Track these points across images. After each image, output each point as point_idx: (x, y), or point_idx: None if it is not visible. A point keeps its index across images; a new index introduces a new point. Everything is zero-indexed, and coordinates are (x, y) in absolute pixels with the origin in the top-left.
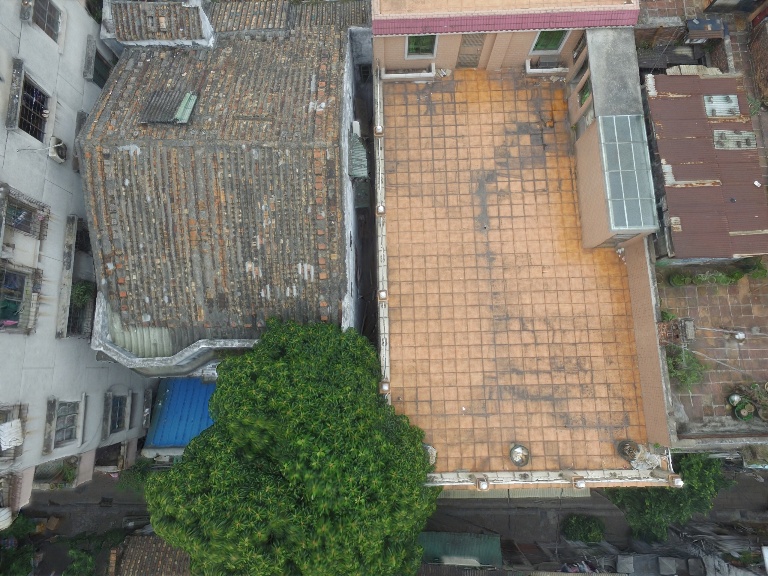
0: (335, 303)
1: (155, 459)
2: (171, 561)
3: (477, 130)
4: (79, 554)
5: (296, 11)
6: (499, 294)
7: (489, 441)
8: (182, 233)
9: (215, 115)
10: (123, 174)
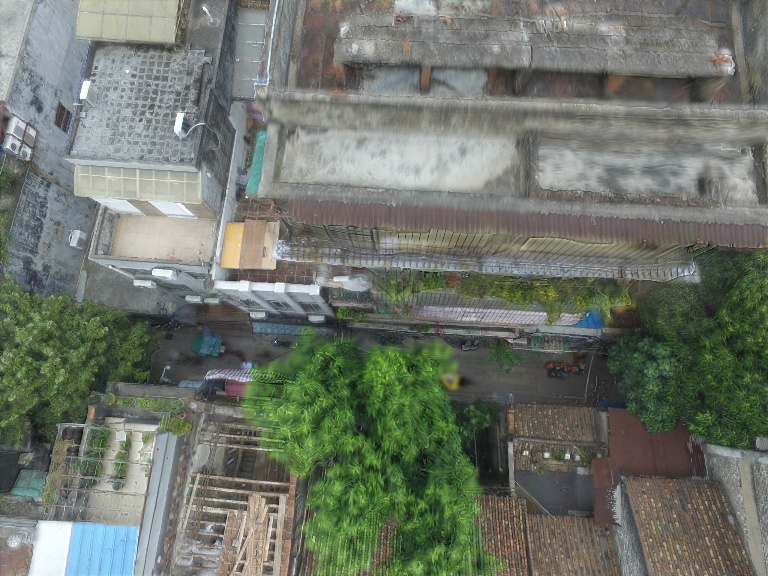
0: None
1: (515, 341)
2: (563, 427)
3: None
4: (474, 412)
5: None
6: None
7: None
8: None
9: None
10: None
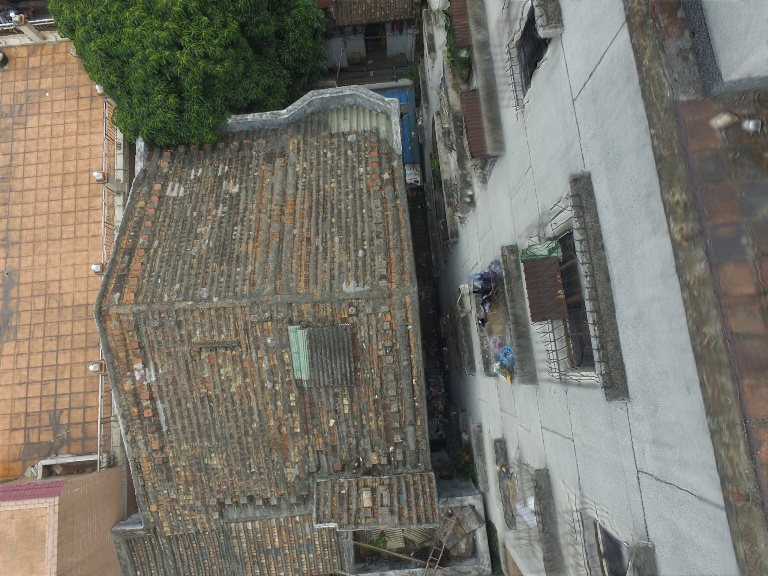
0: (152, 166)
1: None
2: (368, 0)
3: (3, 393)
4: None
5: (229, 564)
6: (1, 204)
7: (27, 70)
8: (302, 211)
9: (264, 348)
10: (365, 262)
